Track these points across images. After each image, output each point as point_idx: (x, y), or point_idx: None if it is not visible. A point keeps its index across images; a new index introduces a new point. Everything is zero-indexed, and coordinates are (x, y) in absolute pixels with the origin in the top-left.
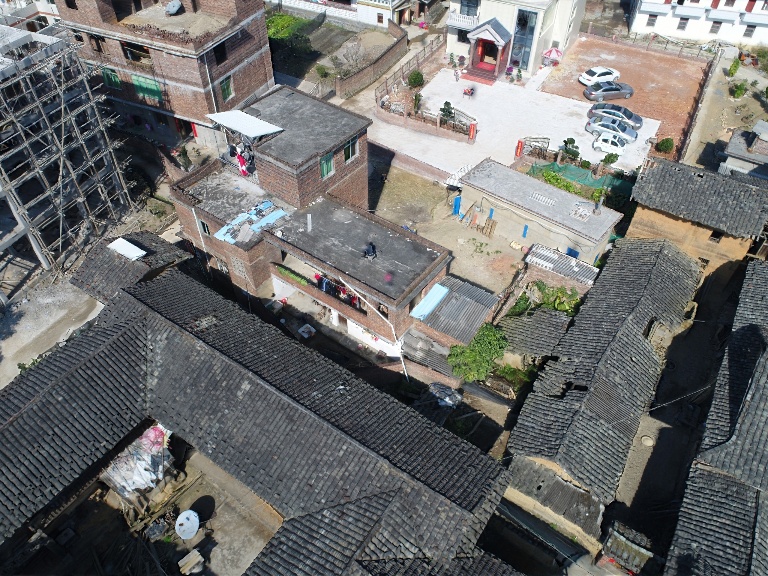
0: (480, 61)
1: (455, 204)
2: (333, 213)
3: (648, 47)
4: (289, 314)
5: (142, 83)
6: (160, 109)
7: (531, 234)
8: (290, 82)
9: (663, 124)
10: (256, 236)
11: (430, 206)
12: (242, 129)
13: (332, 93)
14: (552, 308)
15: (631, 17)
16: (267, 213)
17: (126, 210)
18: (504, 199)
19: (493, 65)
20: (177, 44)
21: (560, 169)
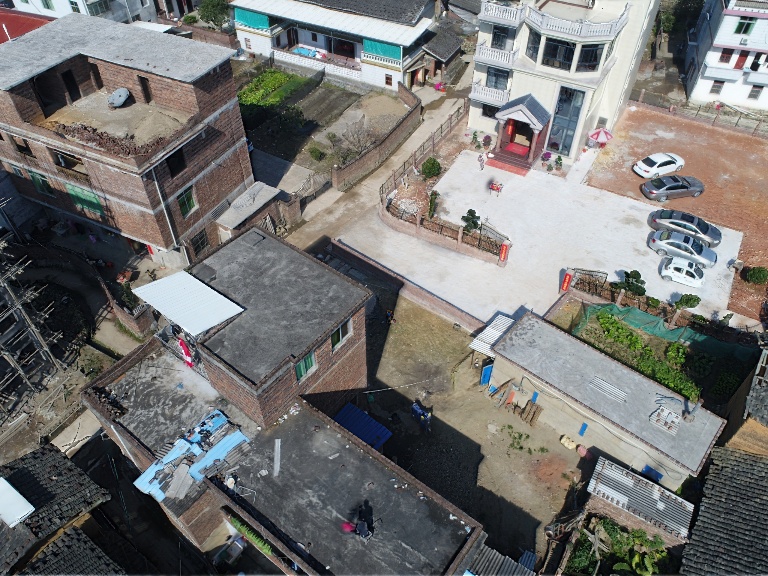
0: (510, 141)
1: (484, 374)
2: (313, 438)
3: (714, 122)
4: (252, 560)
5: (79, 193)
6: (103, 224)
7: (591, 435)
8: (277, 166)
9: (746, 237)
10: (196, 488)
11: (450, 365)
12: (181, 318)
13: (327, 185)
14: (628, 568)
15: (689, 80)
16: (216, 439)
17: (50, 367)
18: (555, 388)
19: (526, 147)
20: (115, 157)
21: (621, 312)
